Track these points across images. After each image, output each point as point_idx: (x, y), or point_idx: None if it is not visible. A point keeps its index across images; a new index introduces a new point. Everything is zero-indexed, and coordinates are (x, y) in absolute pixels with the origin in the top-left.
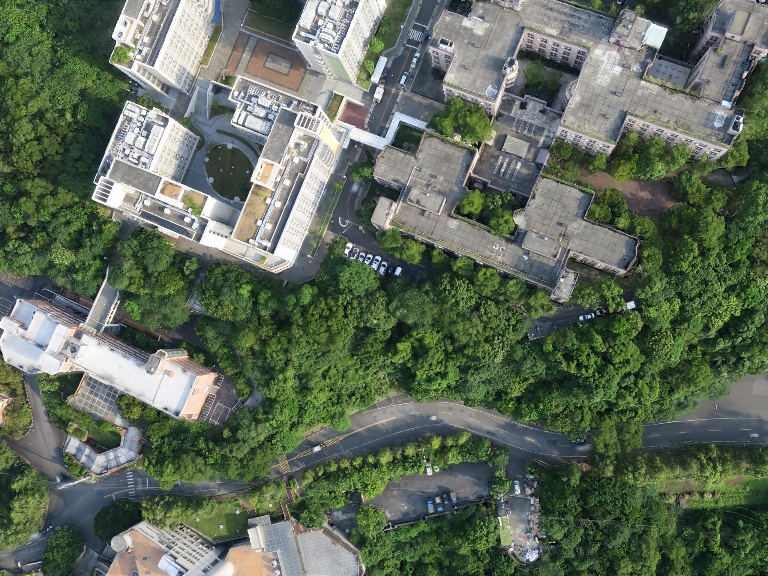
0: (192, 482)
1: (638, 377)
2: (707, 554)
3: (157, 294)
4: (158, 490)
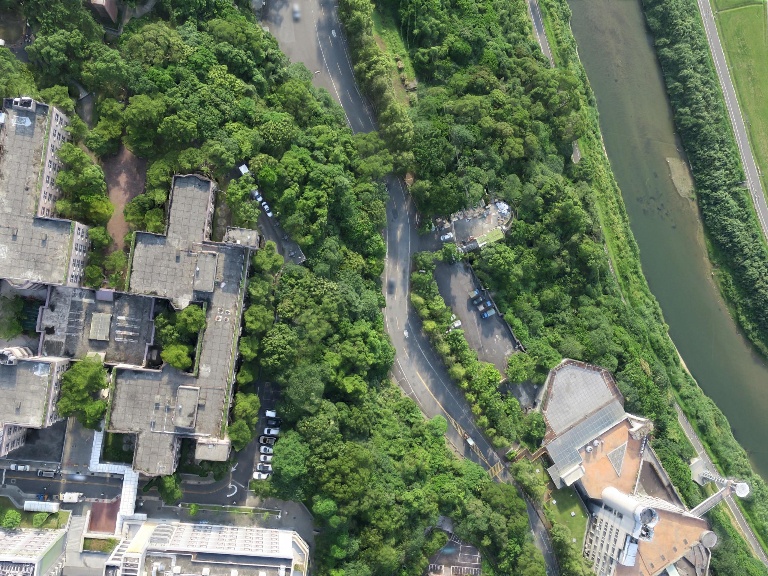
0: None
1: (313, 147)
2: (452, 55)
3: None
4: None
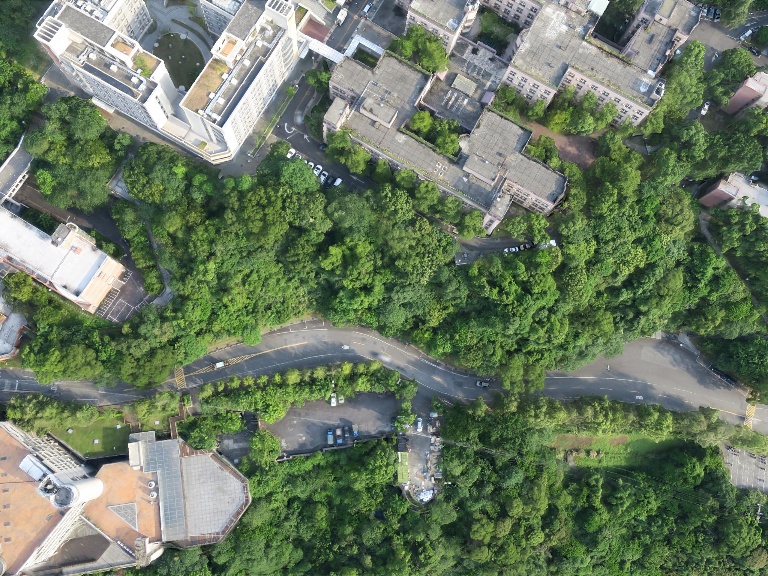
0: (71, 389)
1: (551, 312)
2: (588, 509)
3: (78, 165)
4: (28, 394)
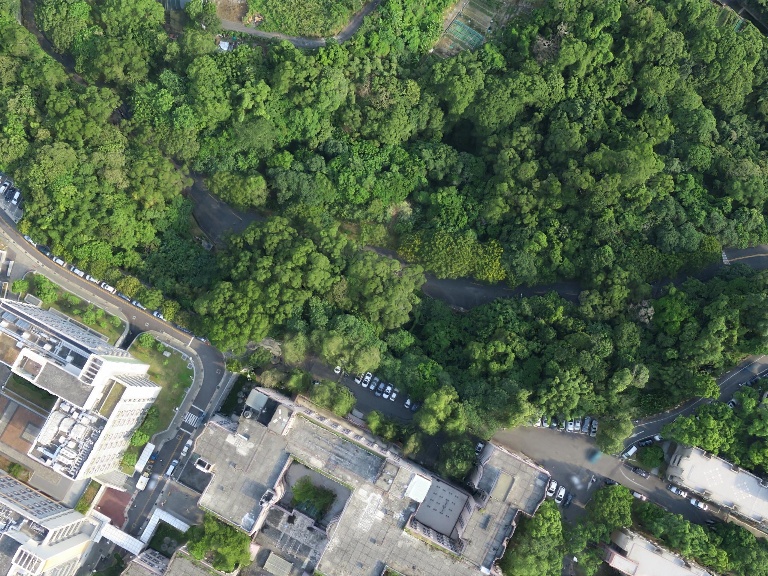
0: None
1: None
2: None
3: None
4: None
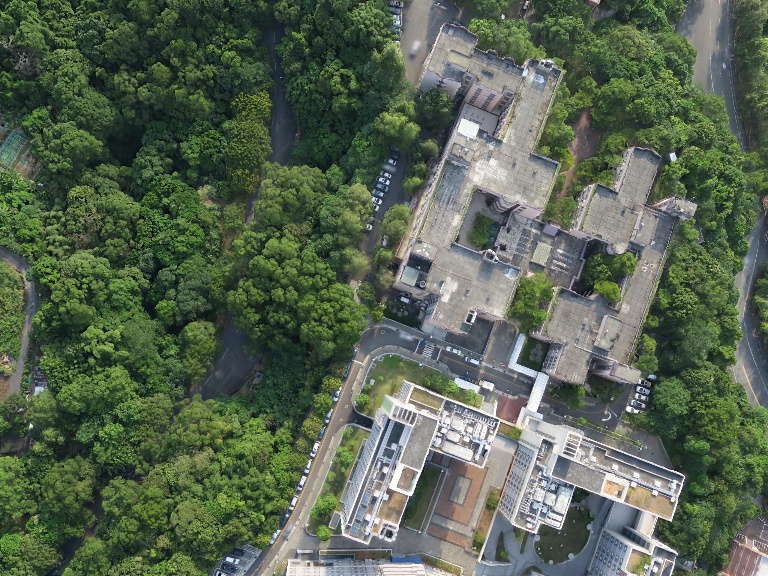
0: None
1: (726, 152)
2: None
3: None
4: None
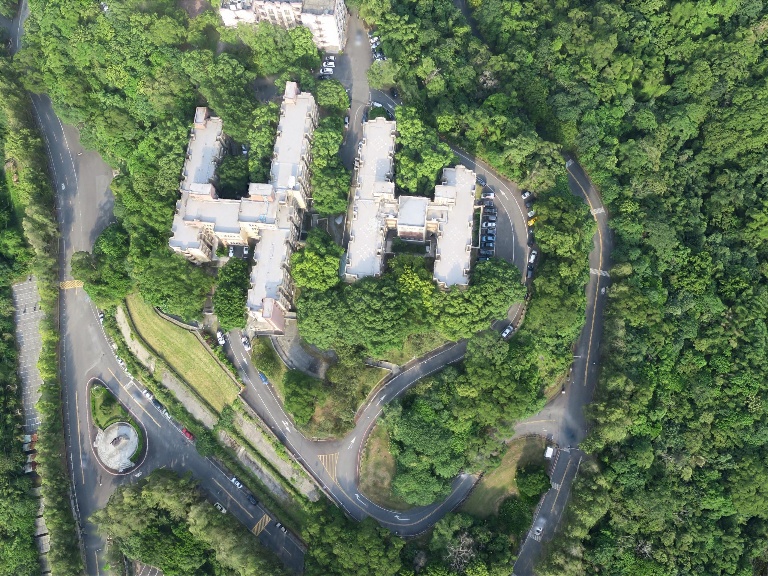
0: None
1: None
2: None
3: None
4: None
